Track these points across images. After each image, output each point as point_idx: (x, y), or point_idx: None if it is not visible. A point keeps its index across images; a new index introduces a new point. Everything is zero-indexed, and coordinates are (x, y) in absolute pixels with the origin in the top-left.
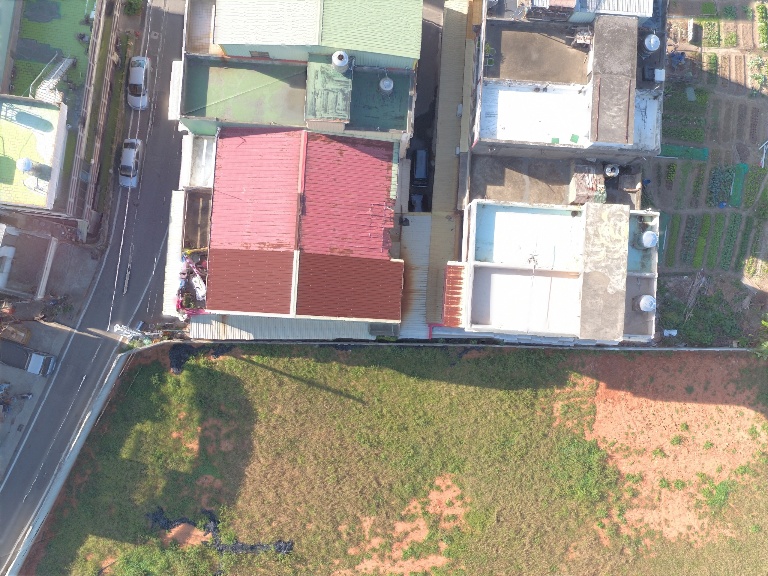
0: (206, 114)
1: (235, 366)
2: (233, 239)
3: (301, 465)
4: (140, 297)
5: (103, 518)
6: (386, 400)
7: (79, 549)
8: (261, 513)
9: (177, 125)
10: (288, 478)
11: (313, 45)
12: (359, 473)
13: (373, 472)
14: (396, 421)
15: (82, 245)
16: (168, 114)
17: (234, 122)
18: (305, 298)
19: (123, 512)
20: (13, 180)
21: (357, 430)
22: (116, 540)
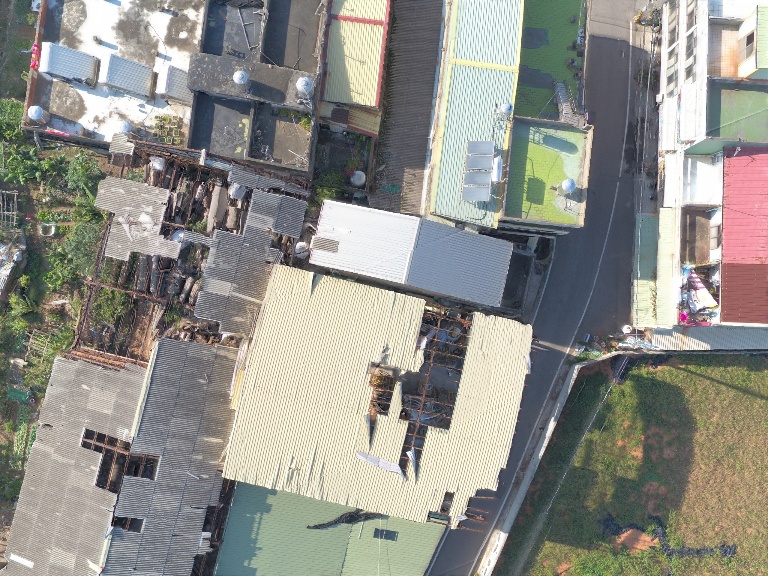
0: (720, 135)
1: (676, 376)
2: (747, 254)
3: (740, 471)
4: (583, 310)
5: (559, 525)
6: None
7: (538, 555)
8: (706, 518)
9: (608, 144)
10: (729, 484)
11: None
12: None
13: None
14: None
15: None
16: (680, 135)
17: (754, 142)
18: None
19: (578, 519)
20: (543, 200)
21: None
22: (572, 546)
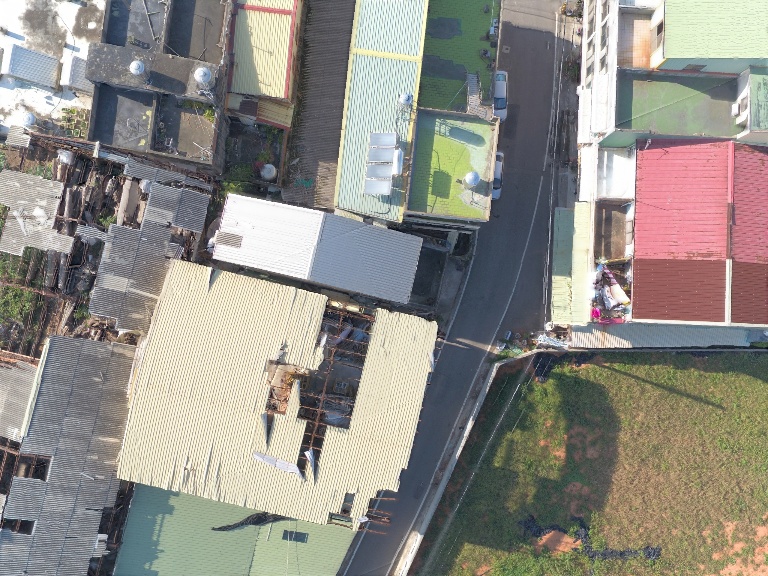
0: (632, 127)
1: (600, 374)
2: (659, 249)
3: (665, 471)
4: (505, 307)
5: (478, 526)
6: (744, 406)
7: (457, 557)
8: (629, 519)
9: (532, 137)
10: (654, 484)
11: (767, 58)
12: (721, 479)
13: (735, 477)
14: (755, 426)
15: (452, 257)
16: (591, 127)
17: (665, 134)
18: (738, 306)
19: (498, 520)
20: (449, 194)
21: (717, 436)
22: (492, 548)
